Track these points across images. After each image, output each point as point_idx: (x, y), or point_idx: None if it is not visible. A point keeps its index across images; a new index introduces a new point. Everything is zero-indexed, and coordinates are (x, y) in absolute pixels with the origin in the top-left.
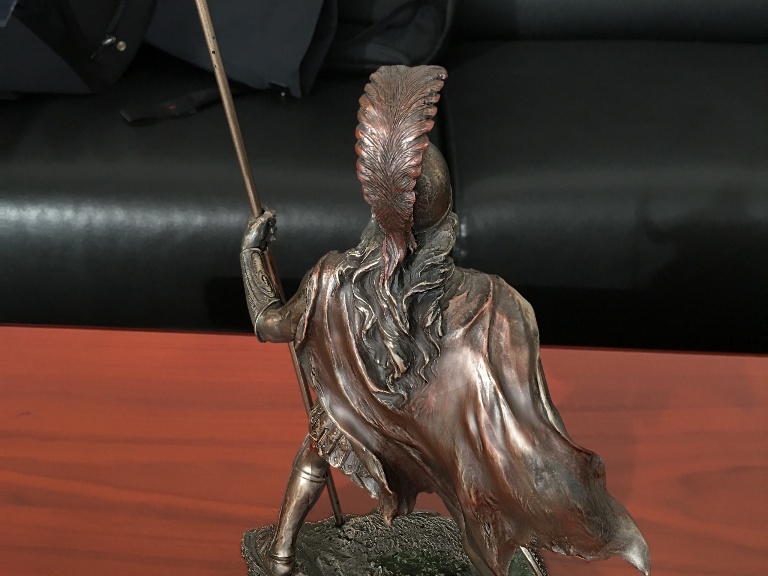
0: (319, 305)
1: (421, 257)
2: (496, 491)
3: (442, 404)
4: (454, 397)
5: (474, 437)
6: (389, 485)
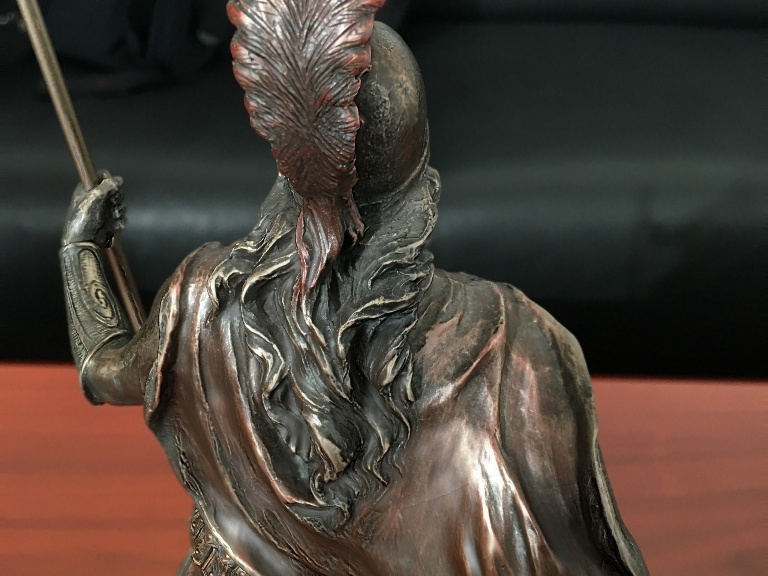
0: (183, 343)
1: (372, 250)
2: None
3: (414, 523)
4: (436, 511)
5: None
6: None
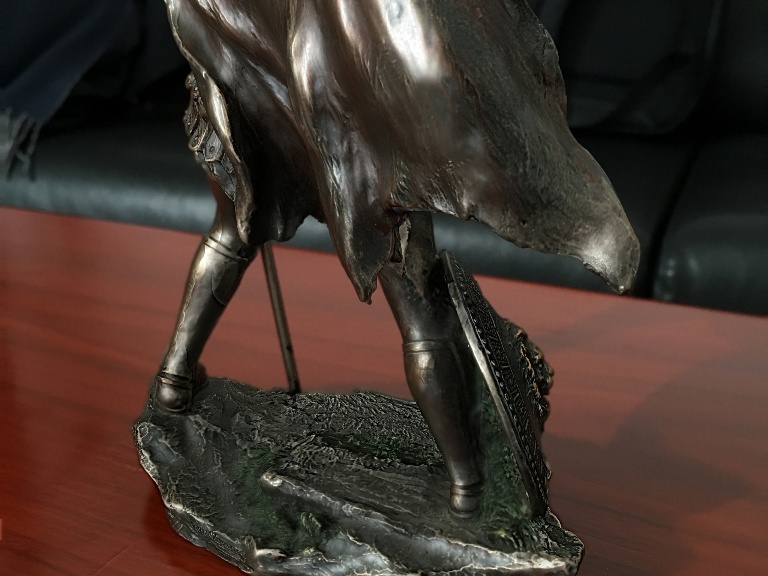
0: None
1: None
2: (339, 68)
3: None
4: None
5: None
6: (235, 143)
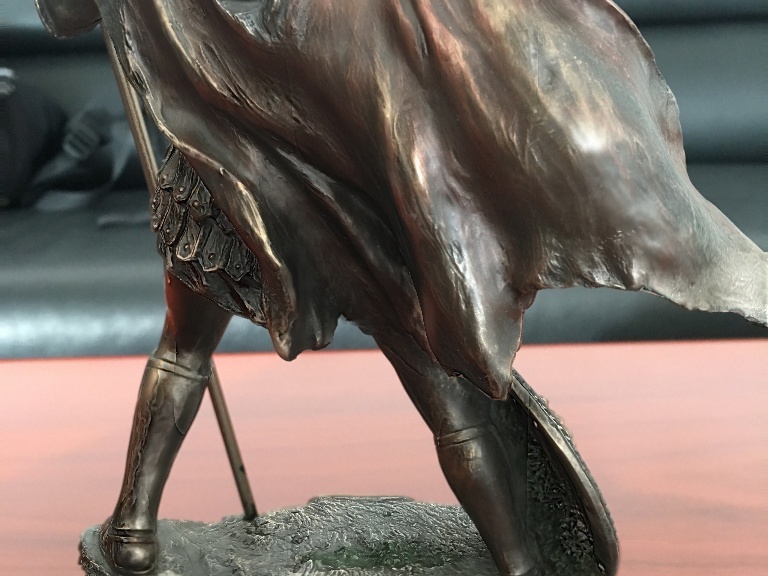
0: None
1: None
2: (464, 145)
3: None
4: None
5: (409, 29)
6: (273, 246)
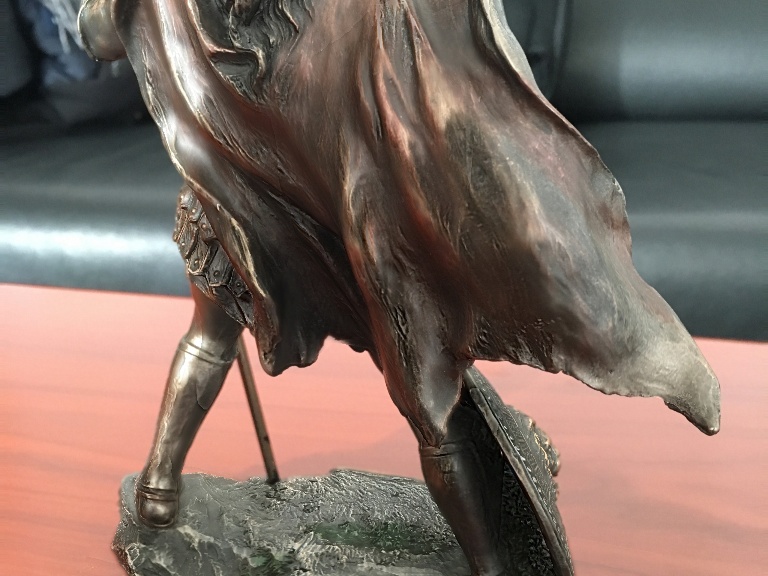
0: None
1: None
2: (408, 224)
3: (322, 70)
4: (341, 51)
5: (367, 112)
6: (259, 278)
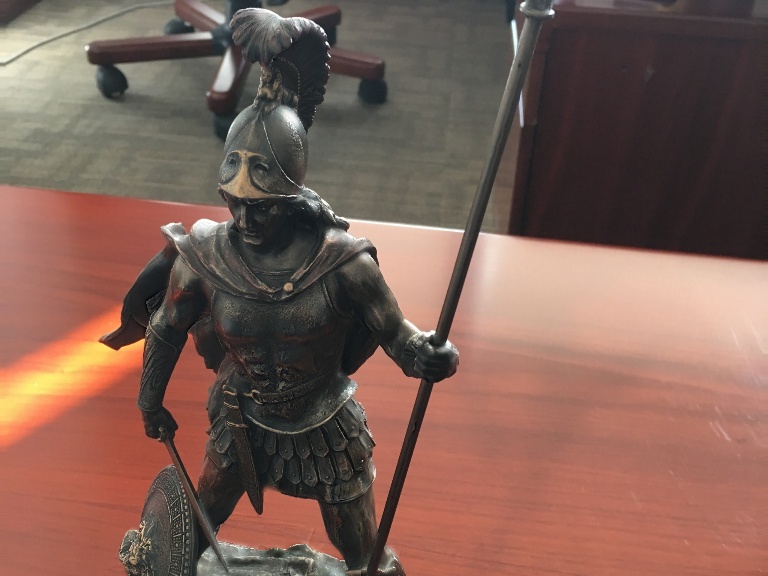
0: None
1: None
2: None
3: None
4: None
5: None
6: None
